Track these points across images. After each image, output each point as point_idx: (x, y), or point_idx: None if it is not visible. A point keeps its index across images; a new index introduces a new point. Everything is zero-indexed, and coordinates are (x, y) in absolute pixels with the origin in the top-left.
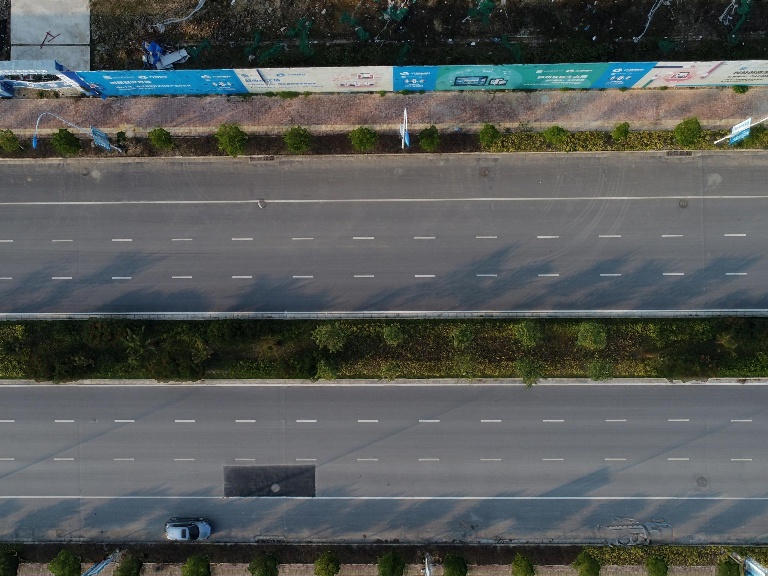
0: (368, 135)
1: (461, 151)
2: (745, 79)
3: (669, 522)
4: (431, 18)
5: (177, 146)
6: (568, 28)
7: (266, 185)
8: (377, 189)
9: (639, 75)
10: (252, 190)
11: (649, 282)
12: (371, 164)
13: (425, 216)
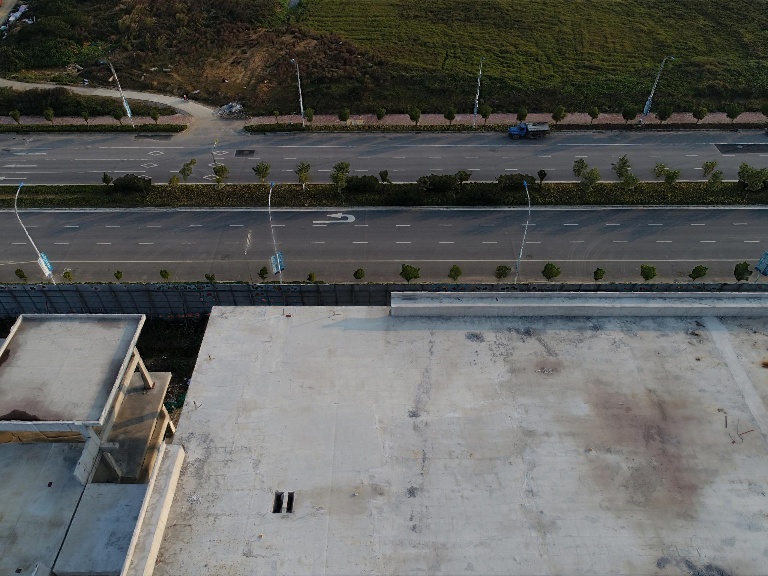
0: None
1: None
2: None
3: (508, 138)
4: None
5: None
6: None
7: None
8: None
9: None
10: None
11: (544, 221)
12: None
13: (713, 252)
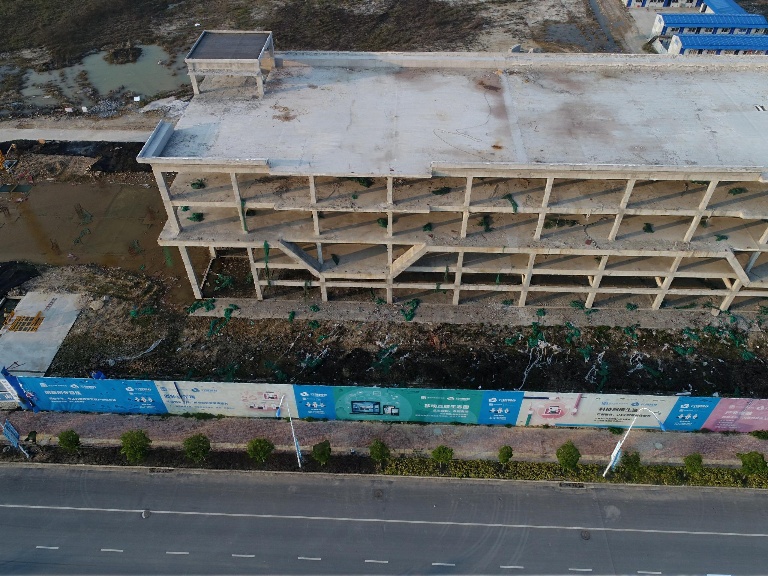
0: (263, 443)
1: (356, 472)
2: (615, 419)
3: None
4: (340, 367)
5: (84, 455)
6: (457, 379)
7: (157, 495)
8: (268, 505)
9: (515, 408)
10: (141, 500)
11: None
12: (267, 481)
13: (313, 535)
